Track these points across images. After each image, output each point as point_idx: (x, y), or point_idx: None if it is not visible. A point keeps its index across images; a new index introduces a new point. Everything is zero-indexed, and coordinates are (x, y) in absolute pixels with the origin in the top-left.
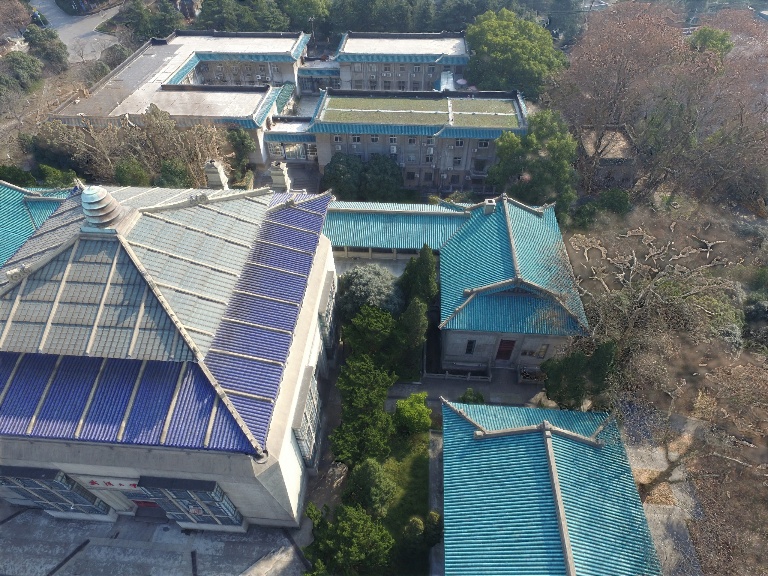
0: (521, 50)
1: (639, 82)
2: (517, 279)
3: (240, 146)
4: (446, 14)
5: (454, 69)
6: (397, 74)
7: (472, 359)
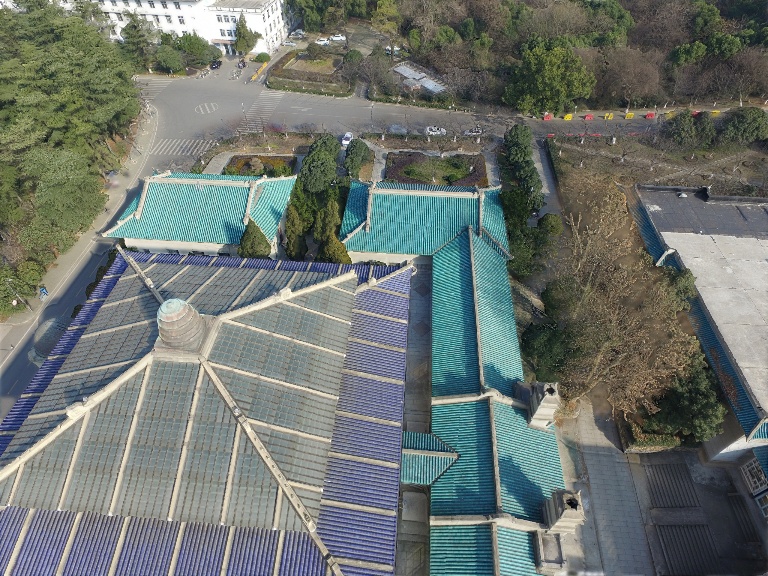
0: None
1: None
2: None
3: (690, 414)
4: None
5: None
6: None
7: None
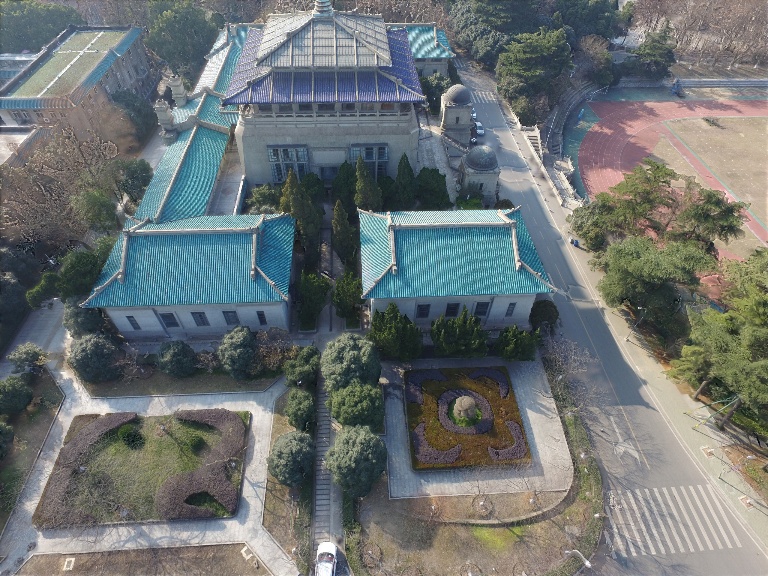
0: (27, 1)
1: (70, 1)
2: None
3: None
4: None
5: None
6: None
7: None
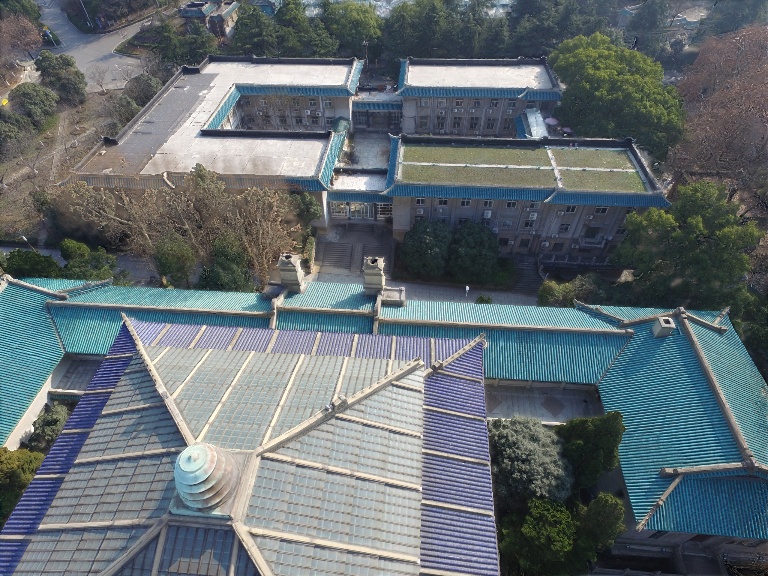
0: (634, 88)
1: None
2: (753, 466)
3: (304, 213)
4: (521, 36)
5: (539, 105)
6: (470, 110)
7: (653, 543)
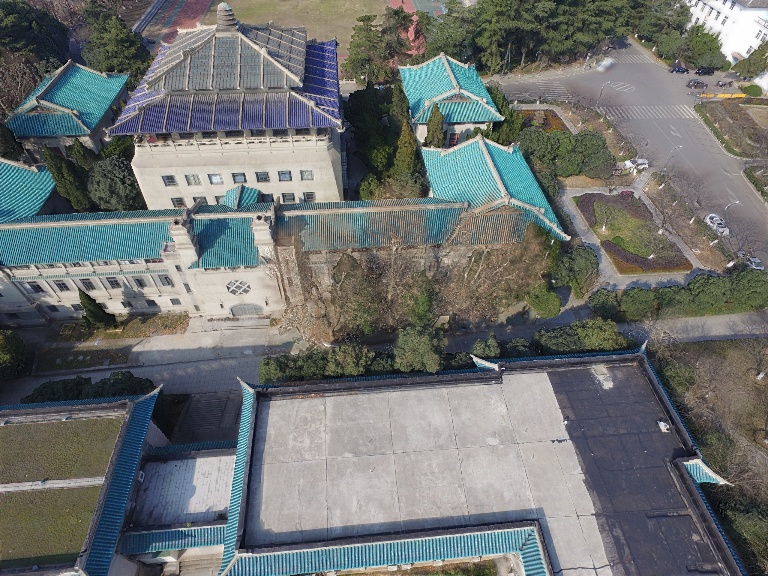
0: None
1: None
2: None
3: None
4: None
5: None
6: None
7: None
